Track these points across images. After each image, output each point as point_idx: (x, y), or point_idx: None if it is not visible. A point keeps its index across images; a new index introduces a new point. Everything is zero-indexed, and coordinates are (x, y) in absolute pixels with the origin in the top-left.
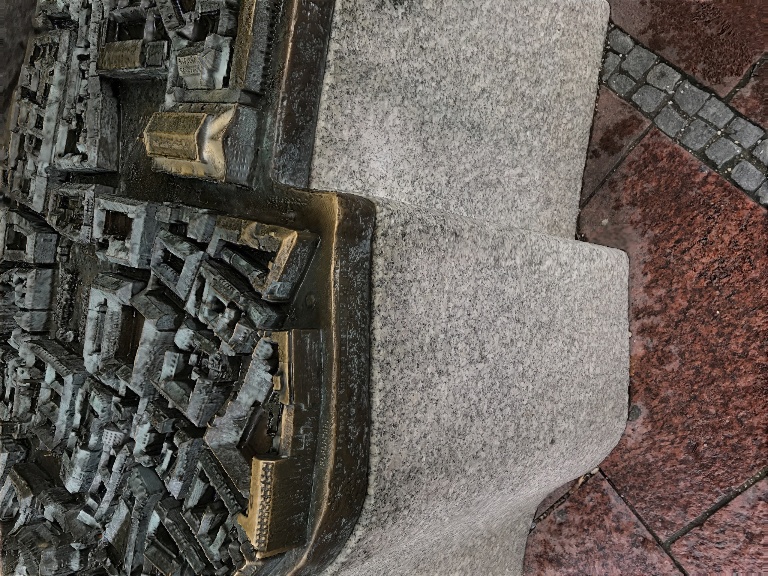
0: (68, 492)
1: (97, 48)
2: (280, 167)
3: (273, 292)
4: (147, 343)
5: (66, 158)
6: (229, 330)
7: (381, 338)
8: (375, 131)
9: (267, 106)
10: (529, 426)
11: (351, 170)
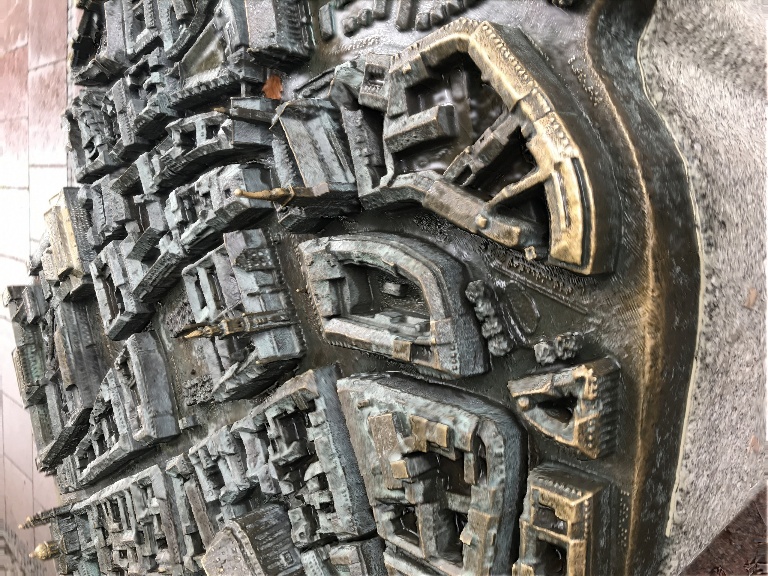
0: None
1: (76, 415)
2: None
3: None
4: None
5: None
6: None
7: None
8: None
9: None
10: None
11: None
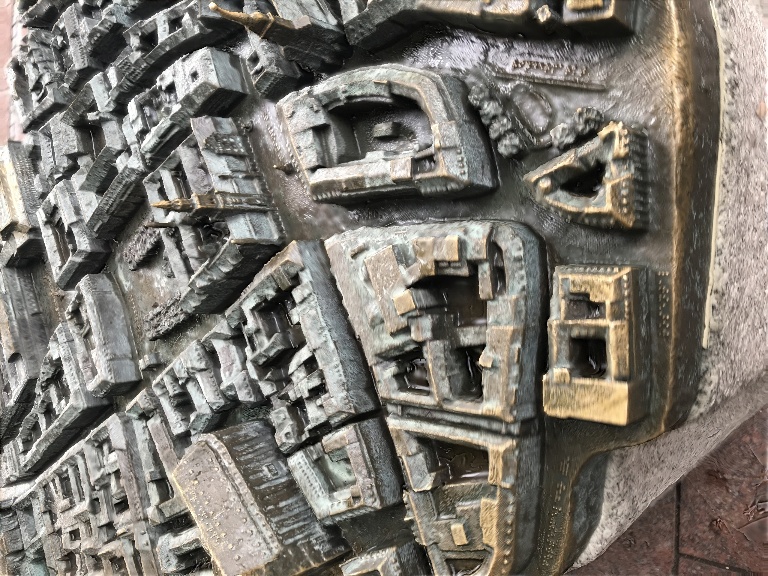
0: None
1: (20, 387)
2: None
3: None
4: None
5: None
6: None
7: None
8: None
9: None
10: None
11: None
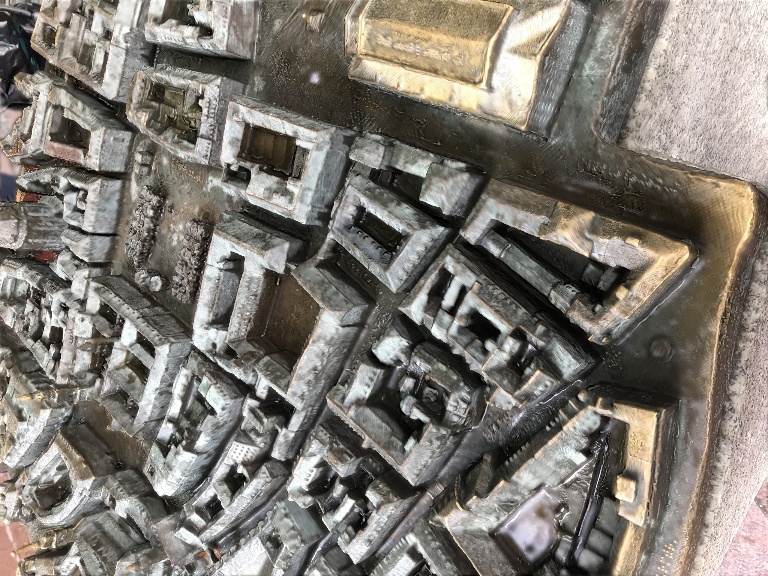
0: (142, 479)
1: None
2: (606, 113)
3: (610, 332)
4: (321, 341)
5: (169, 27)
6: (508, 371)
7: (740, 408)
8: (699, 60)
9: (603, 5)
10: (763, 468)
11: (663, 119)
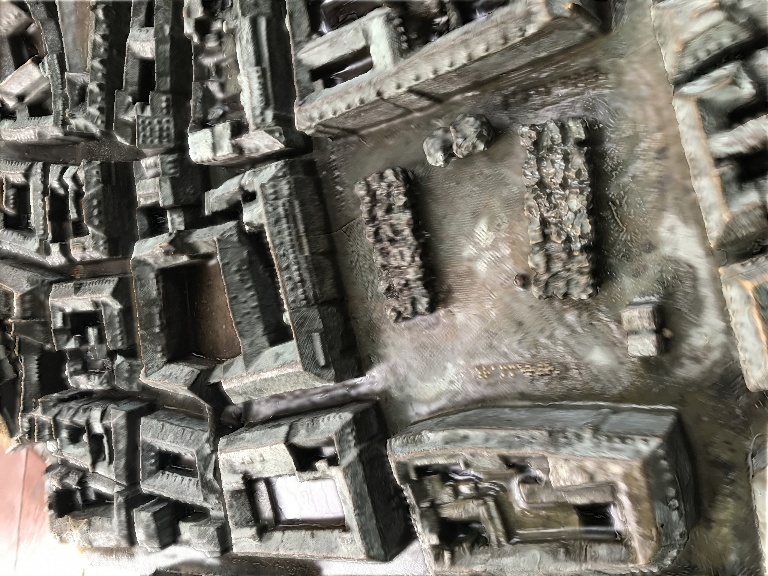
0: None
1: None
2: None
3: None
4: None
5: None
6: None
7: None
8: None
9: None
10: None
11: None
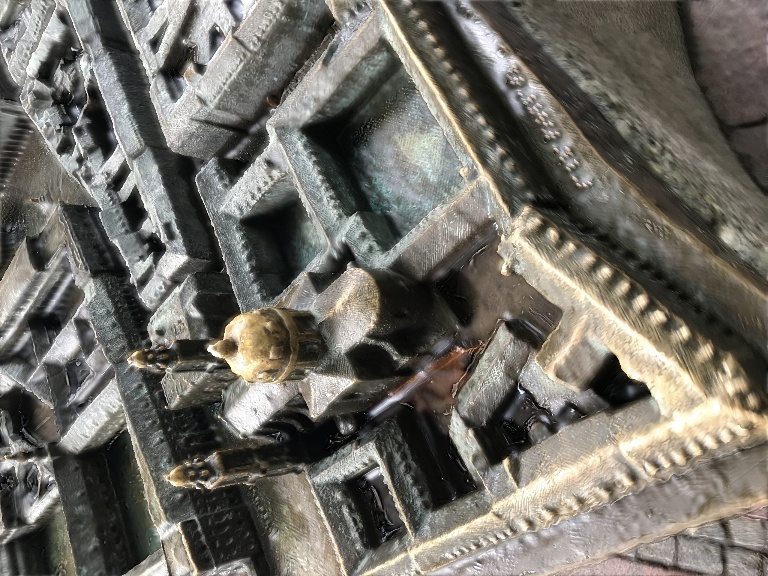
0: None
1: (66, 234)
2: None
3: None
4: None
5: (46, 31)
6: None
7: None
8: None
9: None
10: None
11: None
